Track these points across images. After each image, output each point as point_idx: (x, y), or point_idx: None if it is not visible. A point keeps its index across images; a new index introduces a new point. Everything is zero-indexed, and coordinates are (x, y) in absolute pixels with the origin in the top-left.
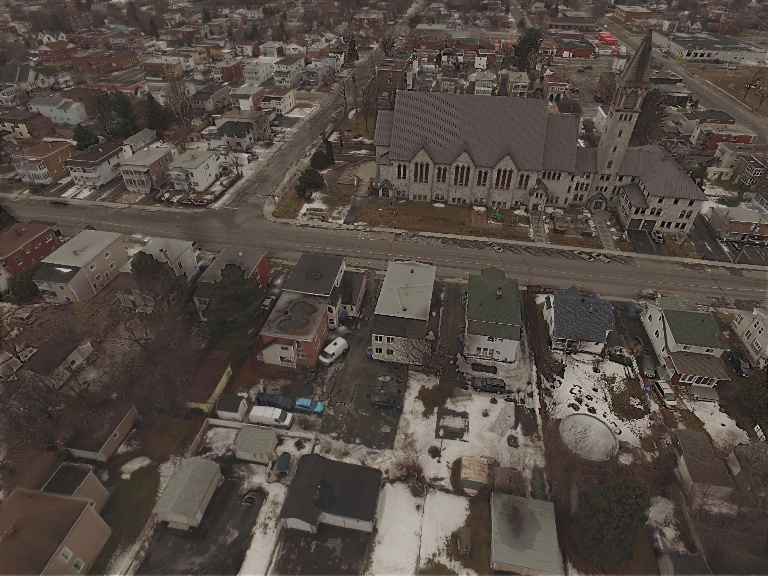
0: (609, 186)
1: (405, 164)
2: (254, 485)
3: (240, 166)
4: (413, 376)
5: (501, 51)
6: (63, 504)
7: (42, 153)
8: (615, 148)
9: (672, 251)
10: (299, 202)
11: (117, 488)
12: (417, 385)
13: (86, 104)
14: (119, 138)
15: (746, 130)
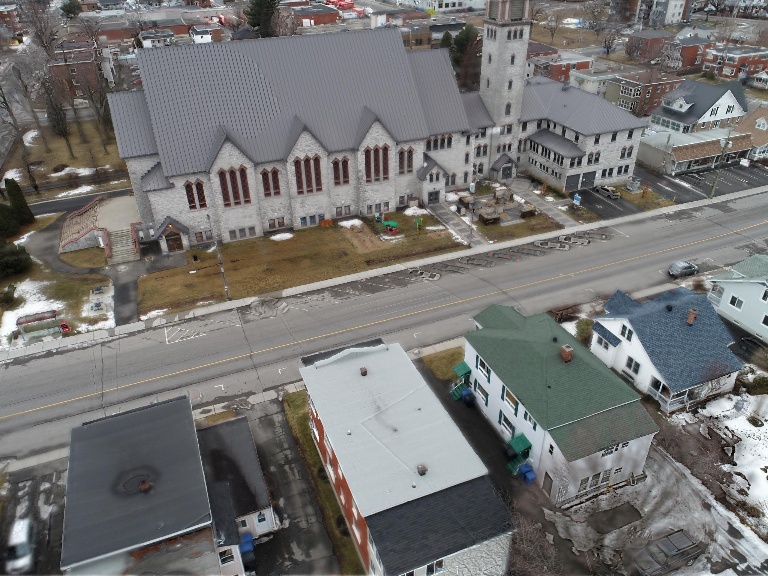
0: (513, 141)
1: (198, 179)
2: None
3: None
4: None
5: None
6: None
7: None
8: (510, 83)
9: (639, 204)
10: None
11: None
12: None
13: None
14: None
15: (578, 56)
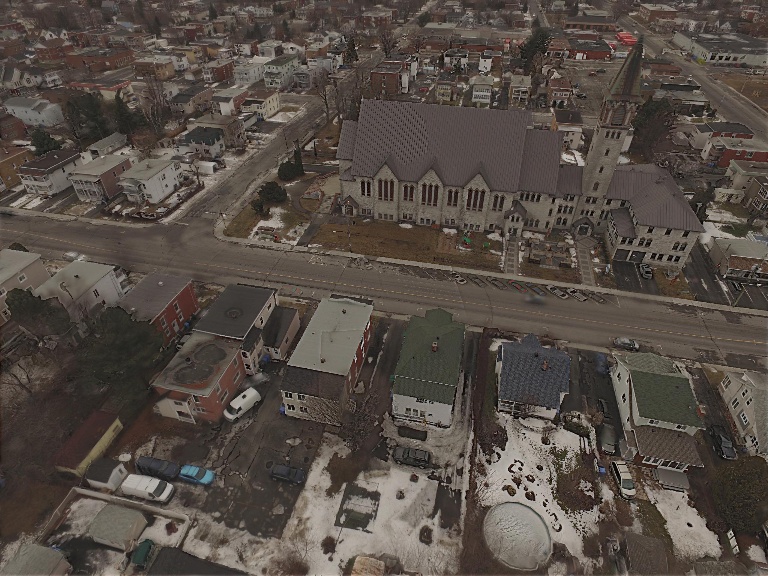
0: (596, 210)
1: (369, 180)
2: None
3: (204, 176)
4: (327, 440)
5: (508, 52)
6: None
7: None
8: (602, 168)
9: (661, 289)
10: (255, 218)
11: None
12: (329, 452)
13: (63, 105)
14: (90, 142)
15: (764, 146)
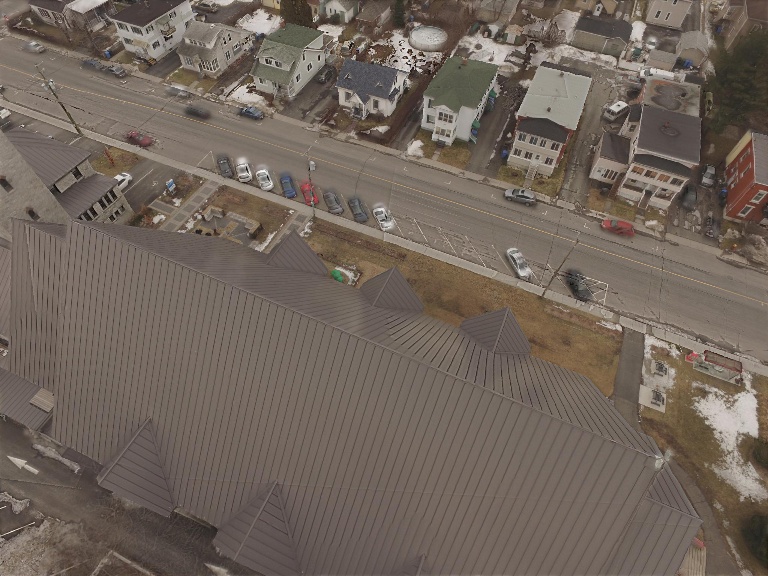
0: None
1: None
2: None
3: None
4: None
5: None
6: (762, 12)
7: None
8: None
9: (132, 164)
10: None
11: None
12: None
13: None
14: None
15: None
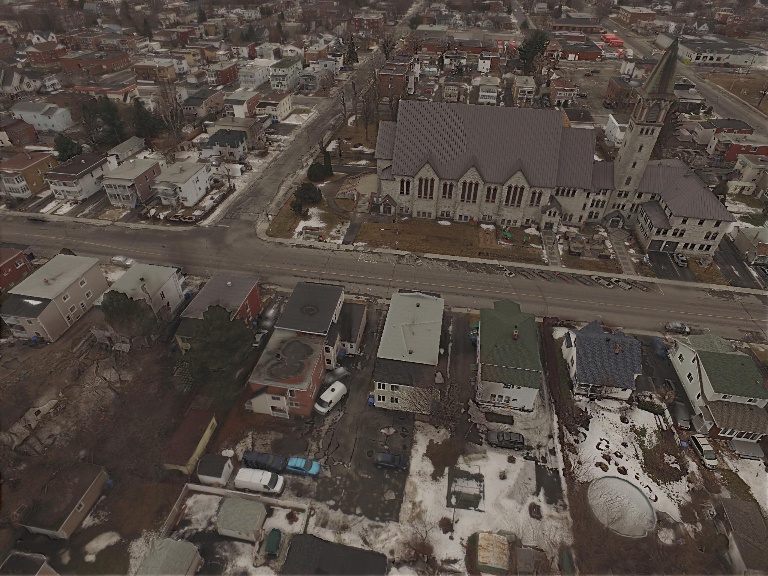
0: (627, 203)
1: (408, 179)
2: (238, 570)
3: (233, 178)
4: (420, 428)
5: (505, 54)
6: None
7: (20, 165)
8: (635, 164)
9: (697, 276)
10: (295, 219)
11: (79, 573)
12: (425, 439)
13: (72, 110)
14: (106, 146)
15: (766, 141)
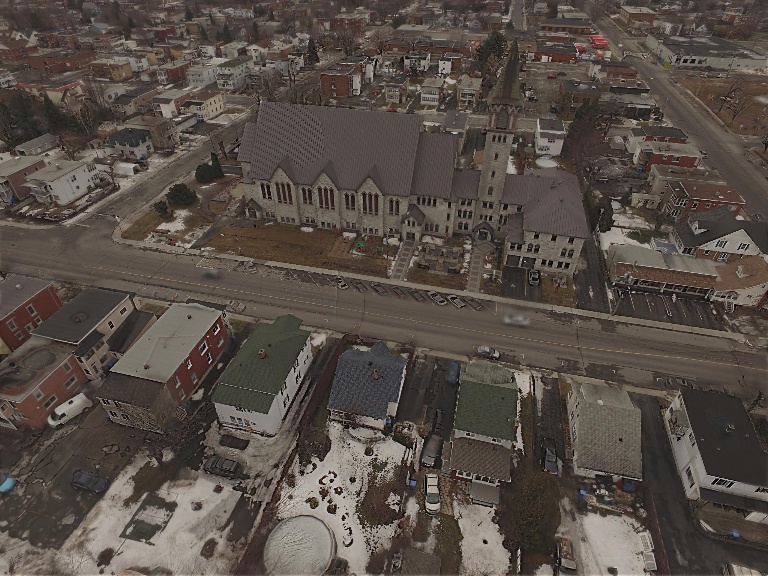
0: (494, 215)
1: (268, 183)
2: None
3: (124, 177)
4: None
5: None
6: None
7: None
8: (493, 173)
9: (544, 296)
10: (158, 221)
11: None
12: (141, 461)
13: None
14: None
15: (692, 150)
